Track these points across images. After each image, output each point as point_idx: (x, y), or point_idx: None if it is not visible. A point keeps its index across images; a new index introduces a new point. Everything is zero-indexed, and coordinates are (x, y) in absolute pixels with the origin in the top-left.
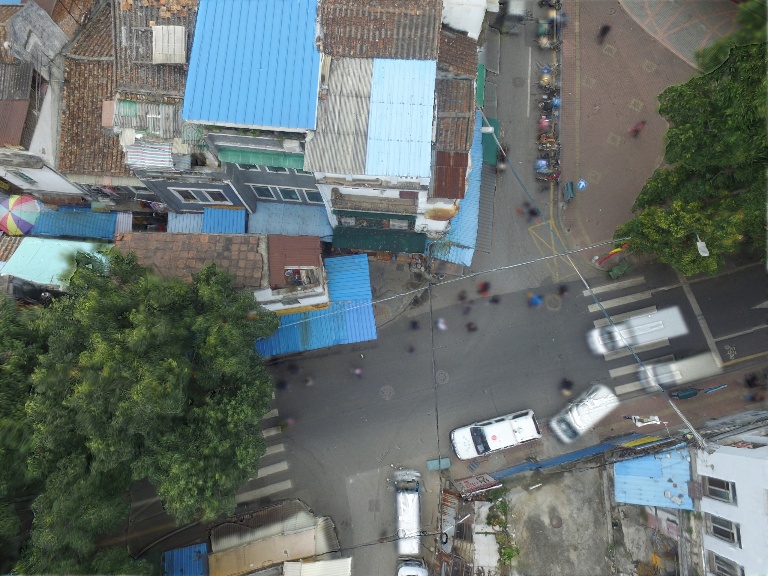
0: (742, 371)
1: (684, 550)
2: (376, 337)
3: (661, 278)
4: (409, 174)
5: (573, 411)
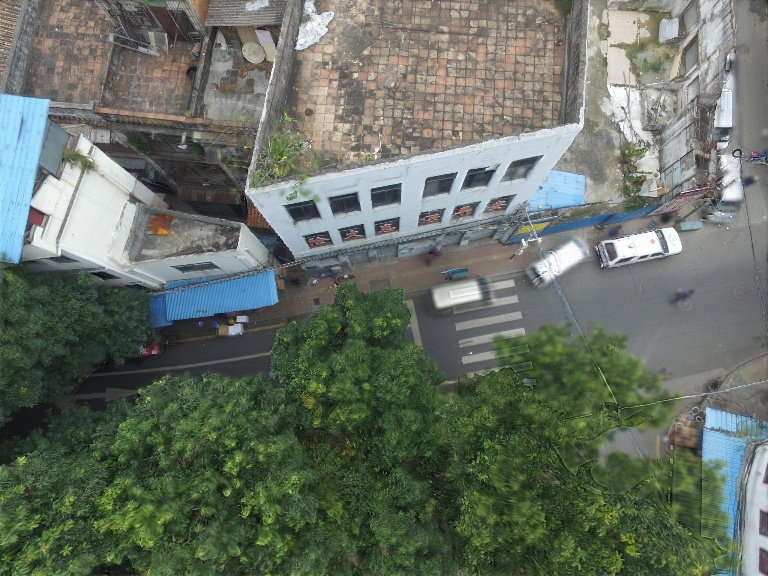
0: None
1: None
2: None
3: (451, 394)
4: None
5: None
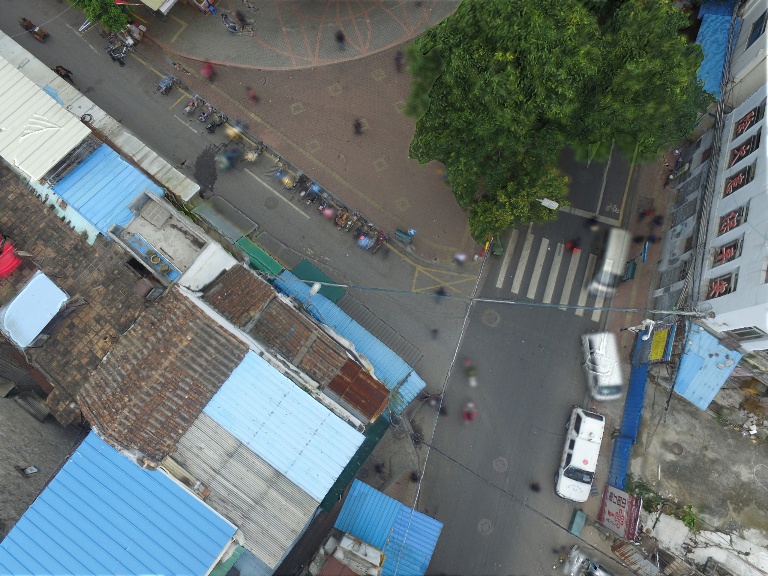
0: (633, 212)
1: (767, 382)
2: (442, 524)
3: None
4: (349, 456)
5: (592, 368)
